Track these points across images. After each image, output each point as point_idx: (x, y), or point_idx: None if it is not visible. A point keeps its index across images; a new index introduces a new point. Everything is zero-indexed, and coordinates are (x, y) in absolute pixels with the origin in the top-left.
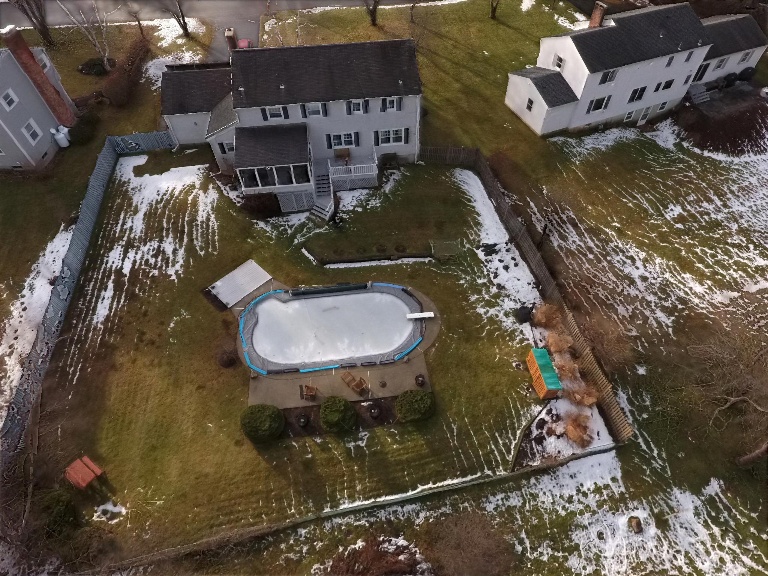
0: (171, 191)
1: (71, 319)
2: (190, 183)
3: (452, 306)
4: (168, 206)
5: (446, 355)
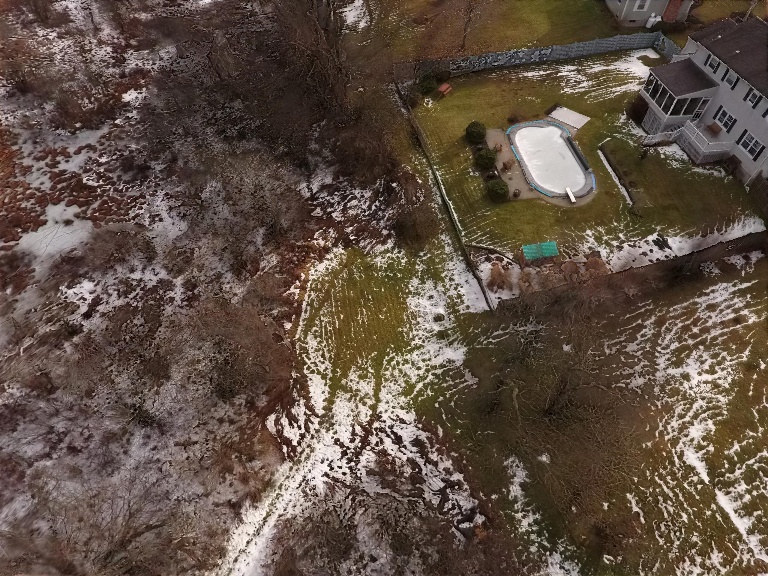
0: (631, 73)
1: (522, 66)
2: (643, 77)
3: (587, 214)
4: (618, 75)
5: (541, 209)
